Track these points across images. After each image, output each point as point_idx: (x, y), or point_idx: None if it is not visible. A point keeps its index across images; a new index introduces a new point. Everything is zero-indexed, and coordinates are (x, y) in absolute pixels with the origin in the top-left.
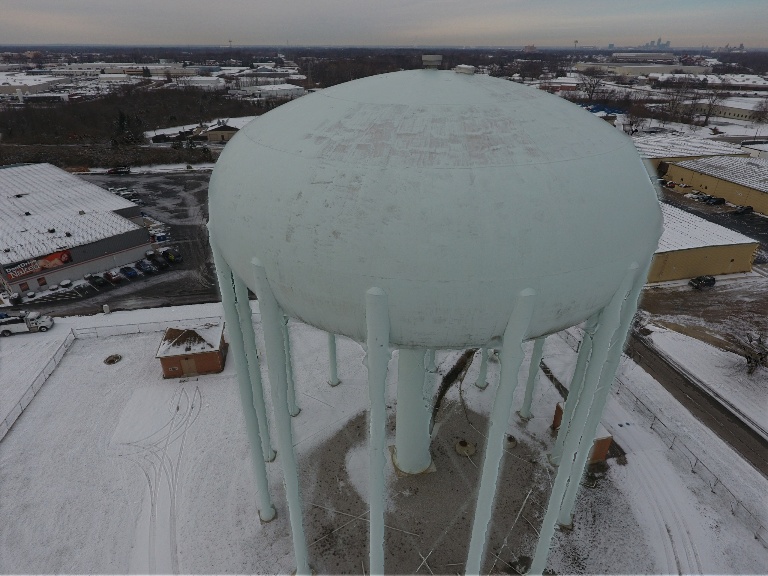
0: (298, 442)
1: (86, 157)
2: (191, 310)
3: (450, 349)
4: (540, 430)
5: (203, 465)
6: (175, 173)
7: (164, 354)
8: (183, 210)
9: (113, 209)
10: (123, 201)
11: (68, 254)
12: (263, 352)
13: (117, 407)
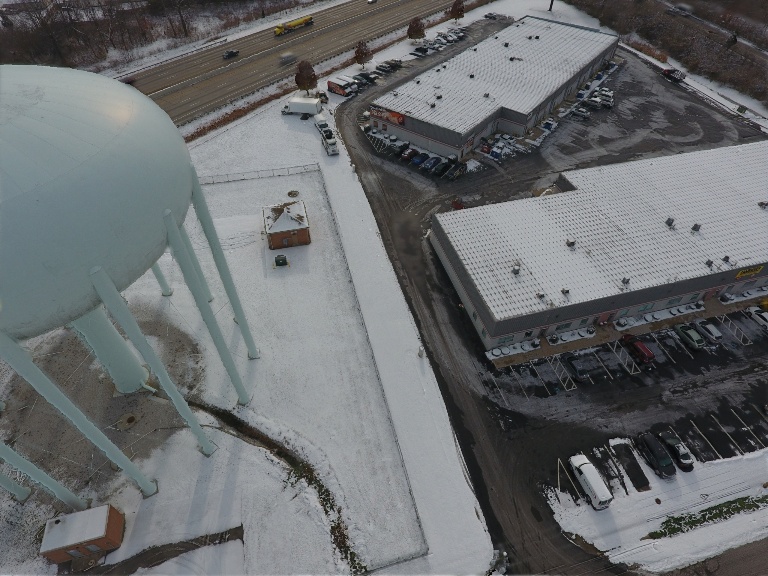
0: (175, 306)
1: (680, 45)
2: (361, 210)
3: (279, 421)
4: (123, 500)
5: (171, 263)
6: (713, 107)
7: (265, 208)
8: (587, 146)
9: (506, 106)
10: (531, 104)
11: (403, 119)
12: (293, 267)
13: (240, 212)
